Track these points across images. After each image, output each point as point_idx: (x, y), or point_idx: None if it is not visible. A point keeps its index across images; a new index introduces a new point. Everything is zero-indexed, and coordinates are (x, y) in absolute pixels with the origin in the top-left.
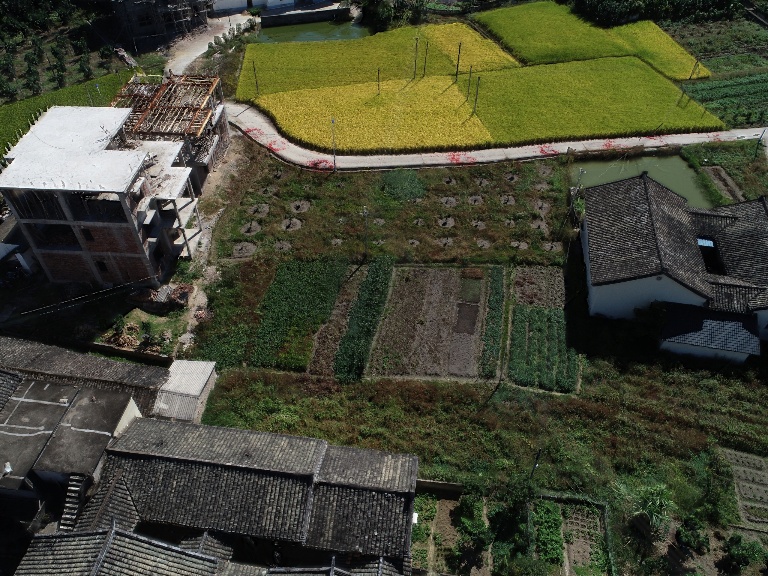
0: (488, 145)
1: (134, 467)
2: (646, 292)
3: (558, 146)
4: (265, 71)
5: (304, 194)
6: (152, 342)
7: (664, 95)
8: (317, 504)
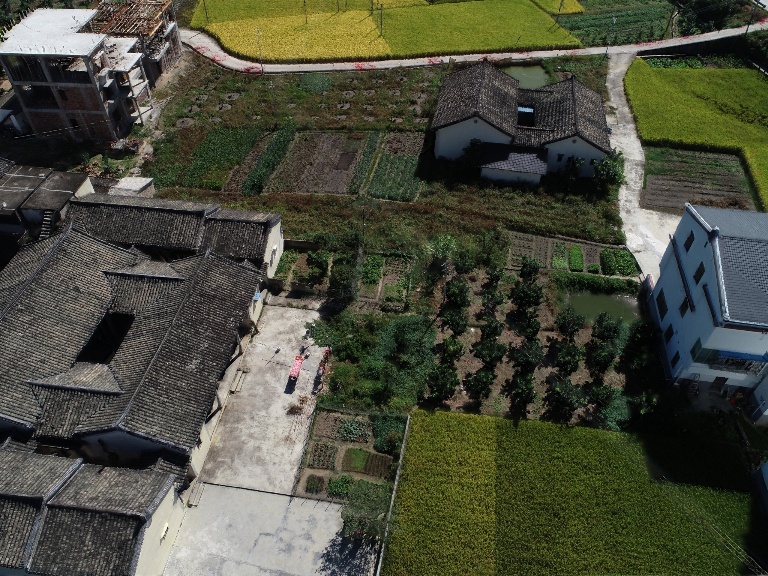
0: (387, 57)
1: (88, 211)
2: (470, 134)
3: (444, 58)
4: (216, 7)
5: (236, 88)
6: (110, 171)
7: (539, 24)
8: (207, 231)
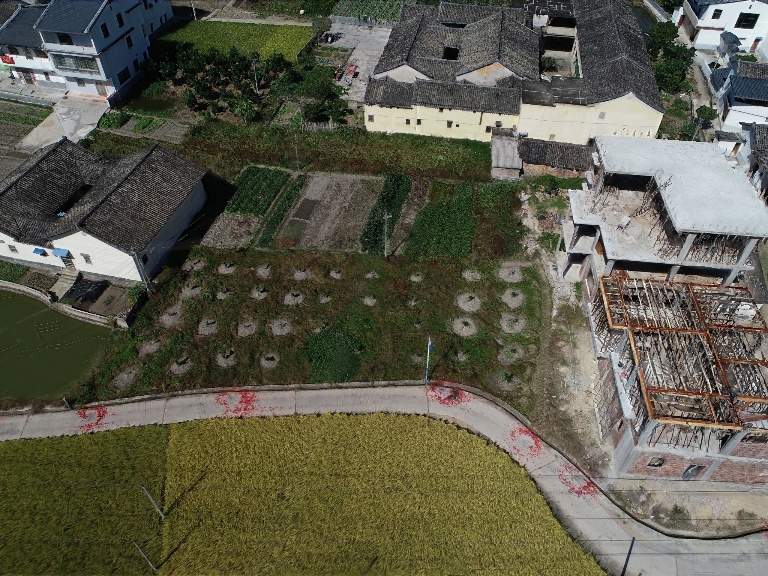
0: None
1: None
2: None
3: (68, 426)
4: None
5: (463, 341)
6: None
7: None
8: None
